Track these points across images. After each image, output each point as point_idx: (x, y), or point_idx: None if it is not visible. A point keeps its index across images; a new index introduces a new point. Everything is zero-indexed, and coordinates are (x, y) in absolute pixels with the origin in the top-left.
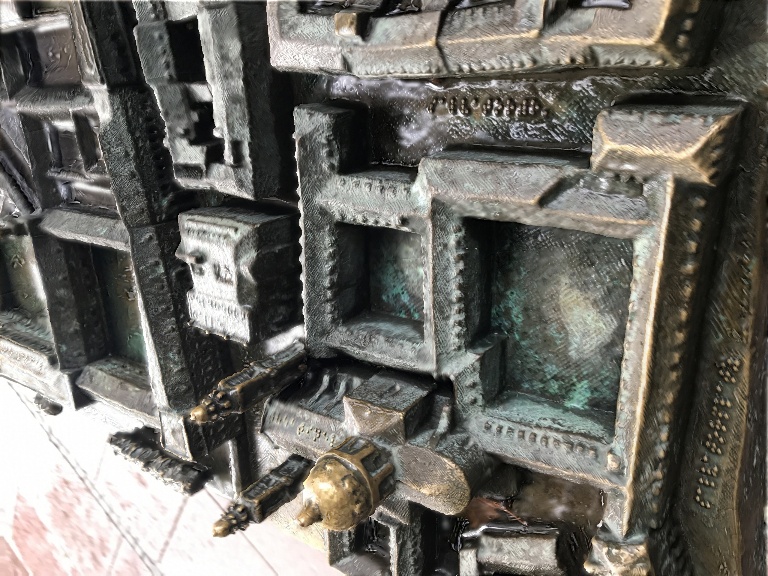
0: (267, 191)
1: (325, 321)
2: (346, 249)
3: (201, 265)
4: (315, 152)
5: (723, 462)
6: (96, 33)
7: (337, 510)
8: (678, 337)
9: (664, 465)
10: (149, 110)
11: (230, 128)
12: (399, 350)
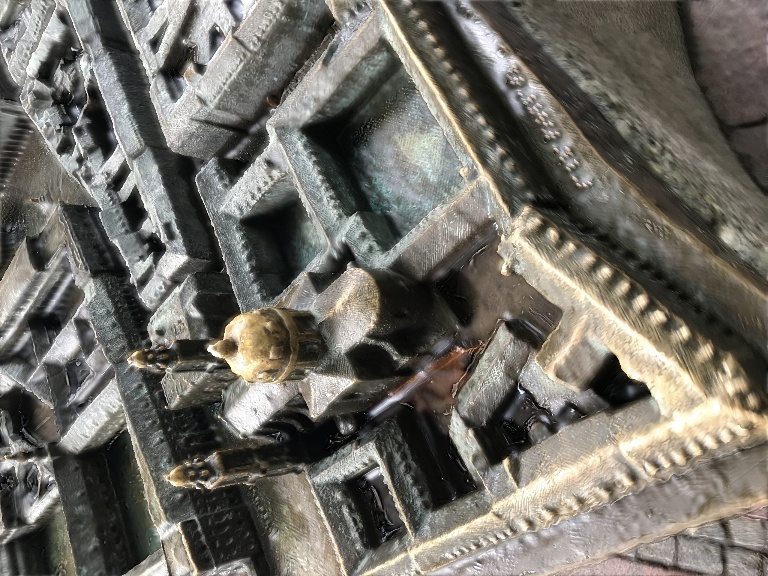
0: (199, 253)
1: (257, 302)
2: (258, 244)
3: (163, 340)
4: (210, 182)
5: (567, 138)
6: (81, 244)
7: (248, 330)
8: (437, 51)
9: None
10: (126, 287)
11: (160, 217)
12: (309, 267)
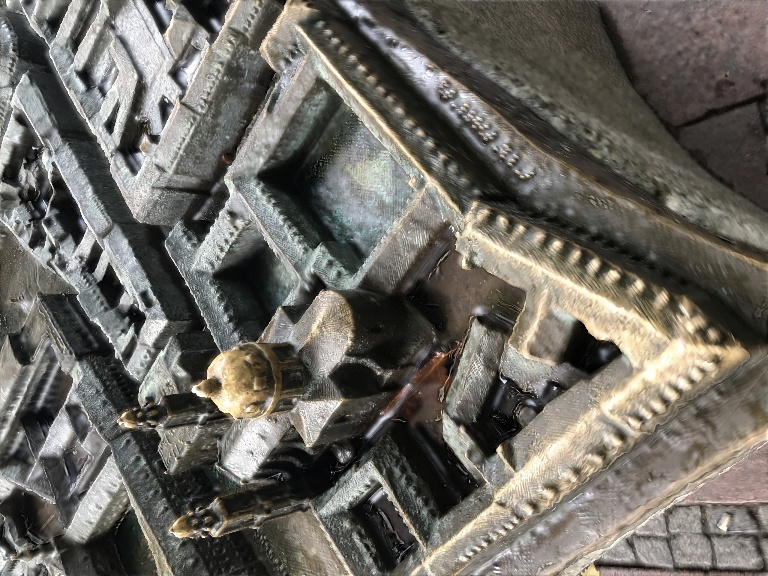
0: (179, 316)
1: None
2: (233, 294)
3: None
4: (179, 244)
5: (503, 137)
6: (63, 330)
7: (229, 366)
8: (370, 79)
9: (444, 152)
10: (113, 365)
11: (136, 287)
12: None
